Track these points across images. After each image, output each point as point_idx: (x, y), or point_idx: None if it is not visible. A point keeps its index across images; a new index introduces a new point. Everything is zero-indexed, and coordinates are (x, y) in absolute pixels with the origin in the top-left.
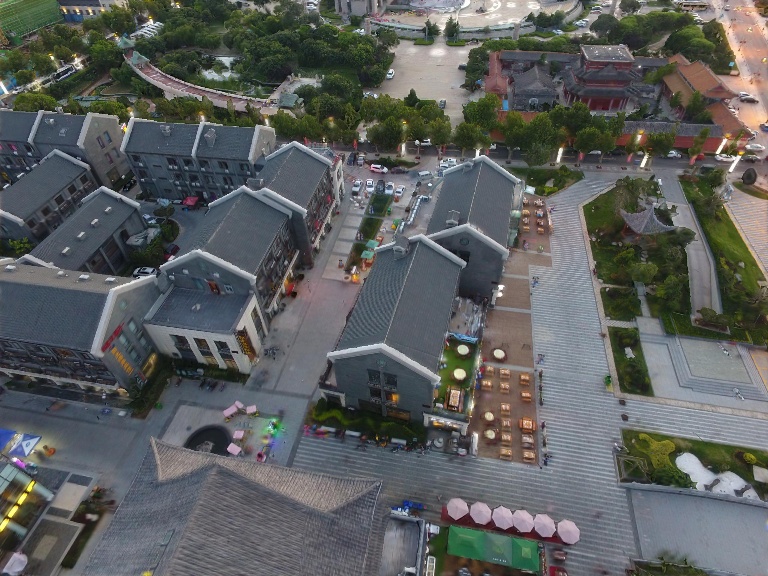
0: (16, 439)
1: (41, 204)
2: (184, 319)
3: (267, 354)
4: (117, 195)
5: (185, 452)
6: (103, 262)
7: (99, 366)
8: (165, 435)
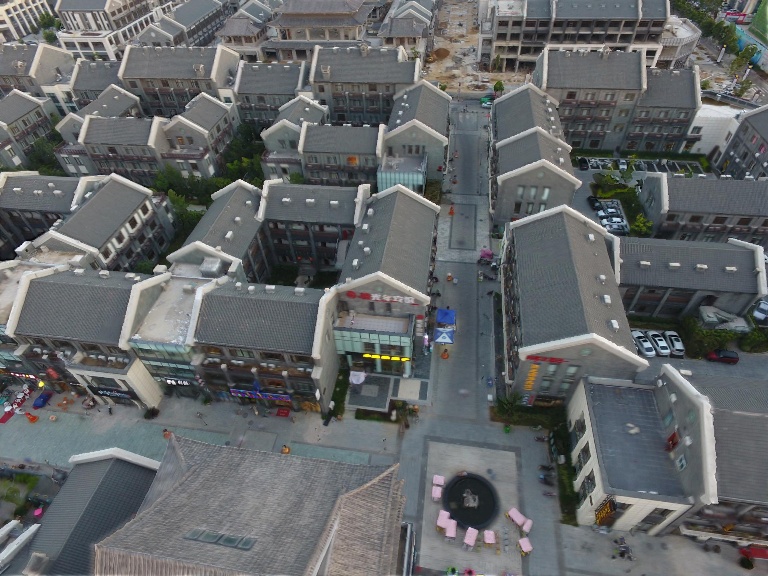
0: (451, 326)
1: (700, 211)
2: (608, 420)
3: (617, 544)
4: (761, 266)
5: (385, 509)
6: (658, 299)
7: (518, 360)
8: (478, 448)
